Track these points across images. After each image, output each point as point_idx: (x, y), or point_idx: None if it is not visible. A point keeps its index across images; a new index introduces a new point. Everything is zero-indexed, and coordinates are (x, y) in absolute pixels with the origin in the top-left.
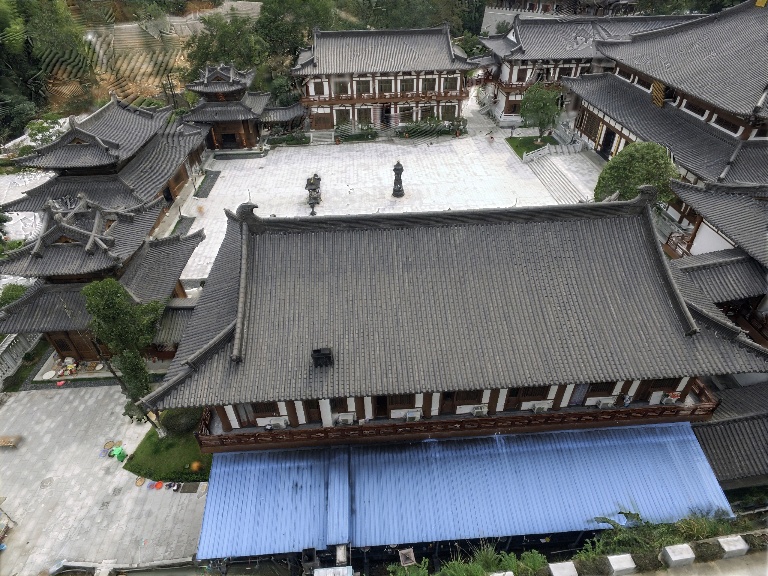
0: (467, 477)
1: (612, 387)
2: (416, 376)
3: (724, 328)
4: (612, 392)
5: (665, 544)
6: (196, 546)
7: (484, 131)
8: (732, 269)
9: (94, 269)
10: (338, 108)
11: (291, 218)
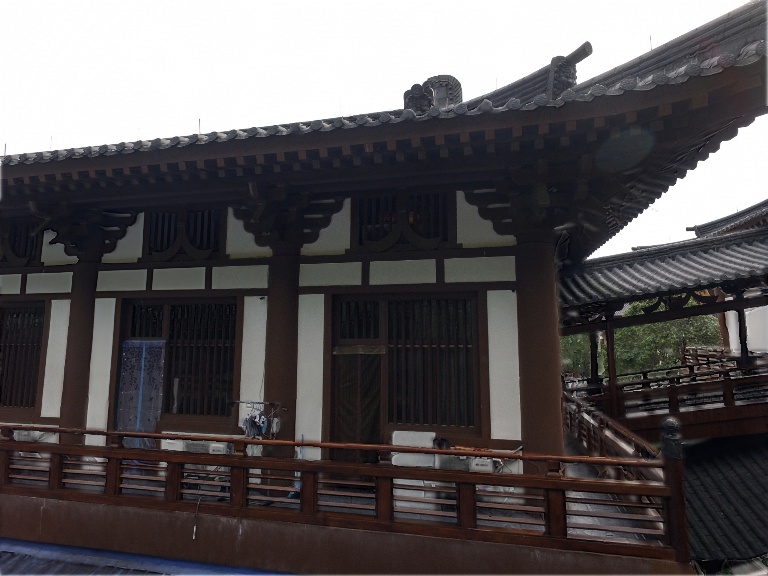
0: None
1: (232, 381)
2: None
3: (522, 88)
4: (237, 409)
5: None
6: None
7: None
8: (736, 250)
9: None
10: None
11: None
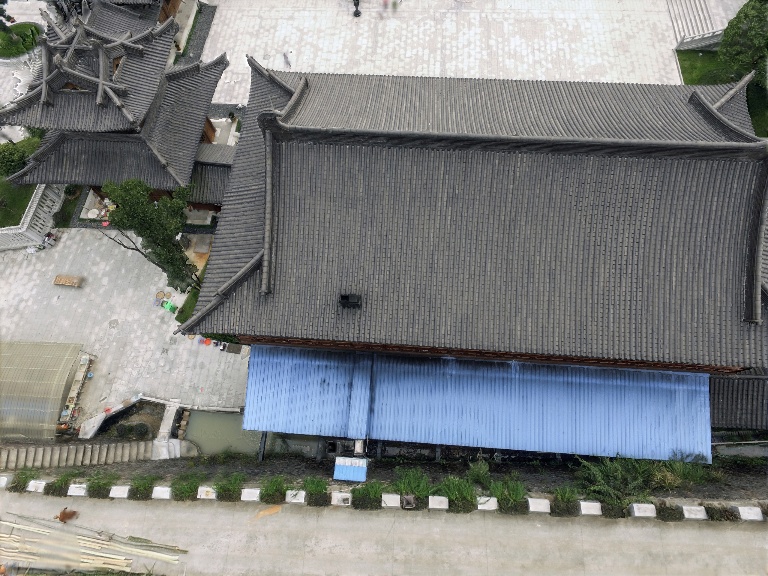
0: (477, 395)
1: None
2: (442, 330)
3: None
4: None
5: (635, 498)
6: (243, 400)
7: None
8: None
9: (111, 129)
10: None
11: (322, 129)
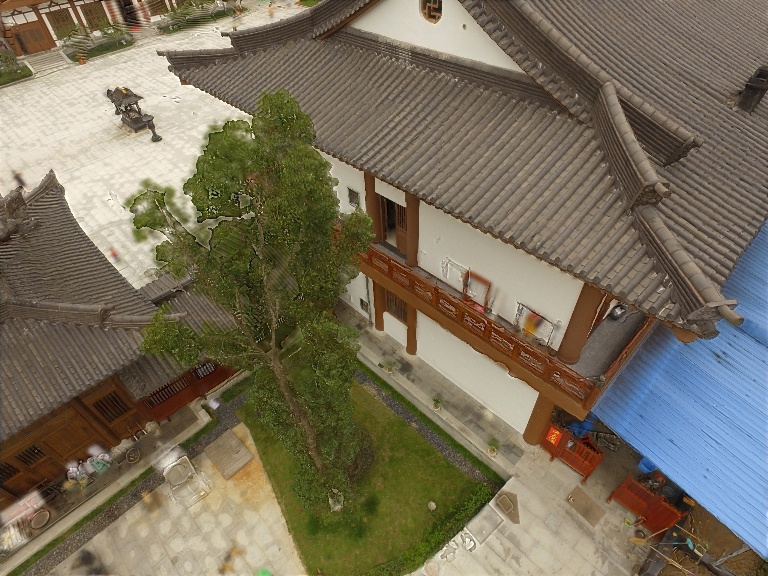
0: None
1: None
2: None
3: None
4: None
5: None
6: None
7: (262, 4)
8: None
9: None
10: (47, 10)
11: None
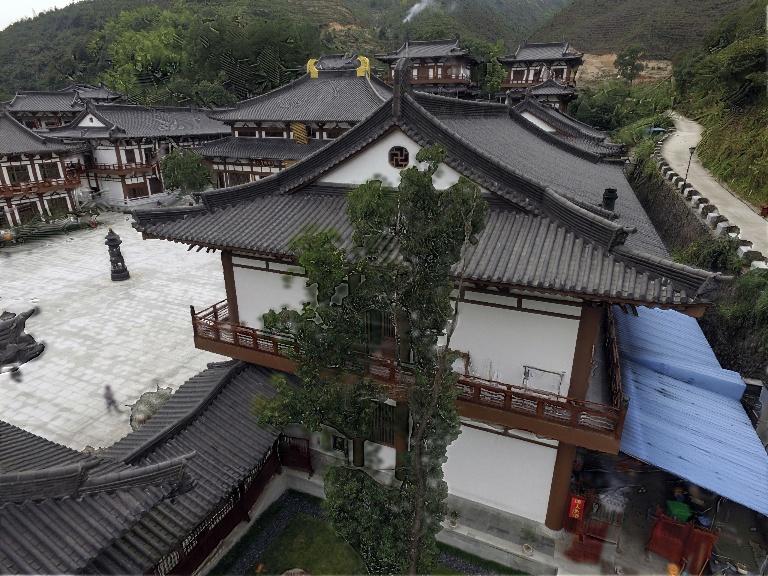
0: None
1: None
2: None
3: None
4: None
5: None
6: None
7: (119, 219)
8: None
9: None
10: None
11: (426, 94)
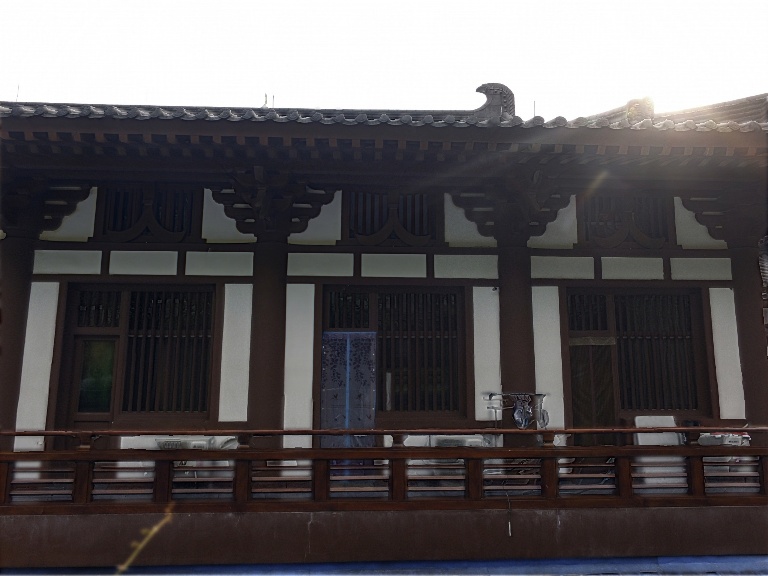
0: None
1: (463, 373)
2: None
3: (728, 112)
4: (472, 403)
5: None
6: None
7: None
8: None
9: None
10: None
11: None
